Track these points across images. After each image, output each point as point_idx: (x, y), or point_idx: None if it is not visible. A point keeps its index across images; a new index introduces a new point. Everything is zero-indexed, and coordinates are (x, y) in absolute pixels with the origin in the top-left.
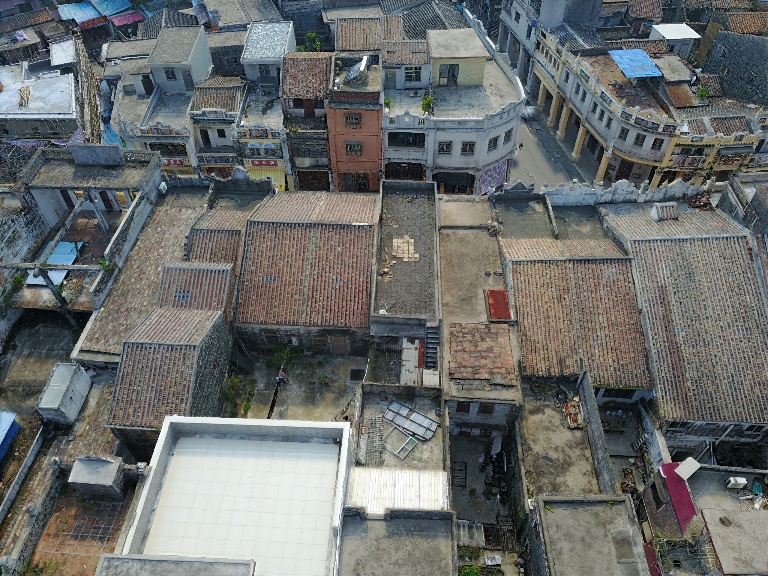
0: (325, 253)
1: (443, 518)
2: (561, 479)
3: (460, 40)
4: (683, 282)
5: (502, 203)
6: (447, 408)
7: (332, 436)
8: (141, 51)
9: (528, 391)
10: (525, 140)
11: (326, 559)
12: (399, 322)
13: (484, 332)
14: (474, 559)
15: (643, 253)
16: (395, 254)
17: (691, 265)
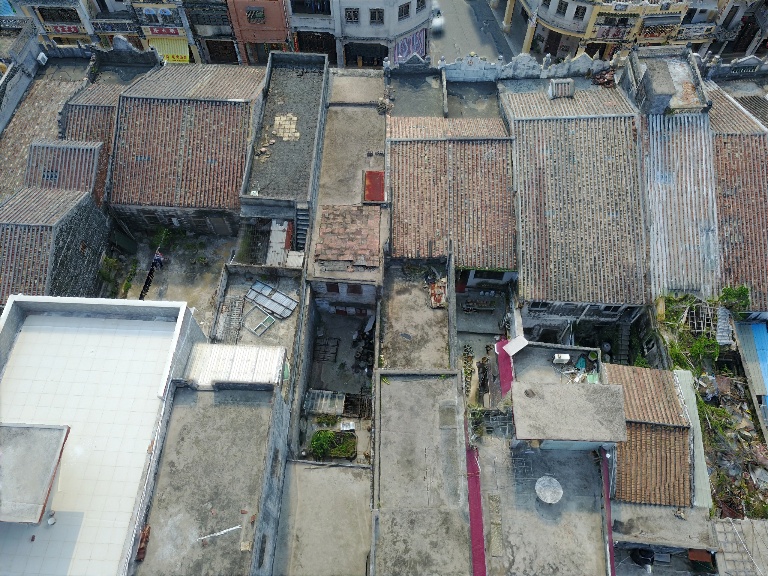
0: (200, 131)
1: (268, 389)
2: (415, 355)
3: None
4: (562, 164)
5: (398, 78)
6: (309, 288)
7: (174, 314)
8: None
9: (399, 272)
10: (457, 6)
11: (154, 425)
12: (269, 203)
13: (355, 214)
14: (331, 425)
15: (526, 133)
16: (275, 133)
17: (573, 146)
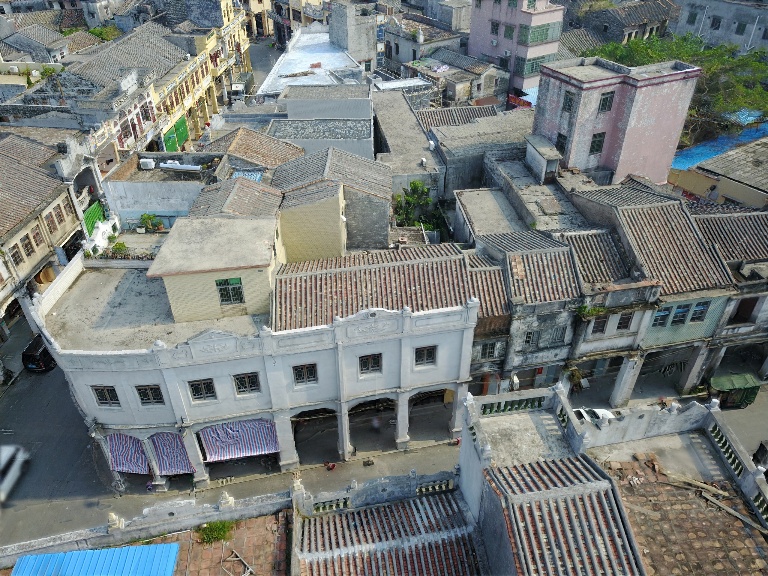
0: None
1: None
2: None
3: (224, 246)
4: None
5: None
6: None
7: None
8: (380, 103)
9: None
10: None
11: None
12: None
13: None
14: None
15: None
16: None
17: None
